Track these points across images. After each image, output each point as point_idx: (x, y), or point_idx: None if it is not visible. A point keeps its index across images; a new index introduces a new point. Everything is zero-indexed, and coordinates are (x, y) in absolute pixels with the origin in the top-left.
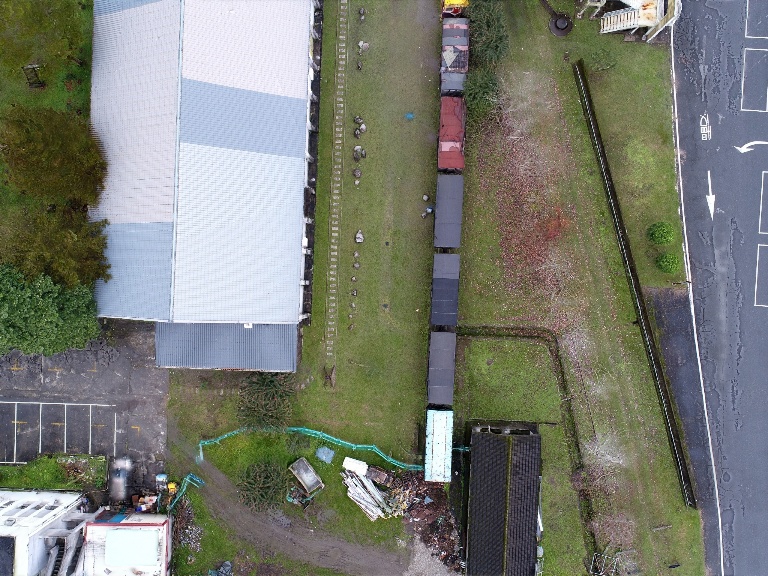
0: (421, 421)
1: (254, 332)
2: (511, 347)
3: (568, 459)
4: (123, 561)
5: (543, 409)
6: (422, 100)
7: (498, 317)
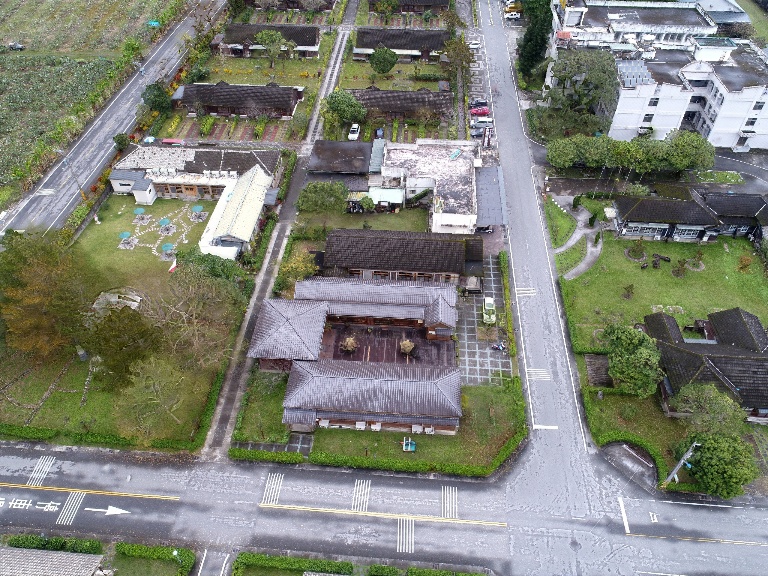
0: None
1: (732, 14)
2: None
3: None
4: None
5: None
6: (749, 3)
7: None
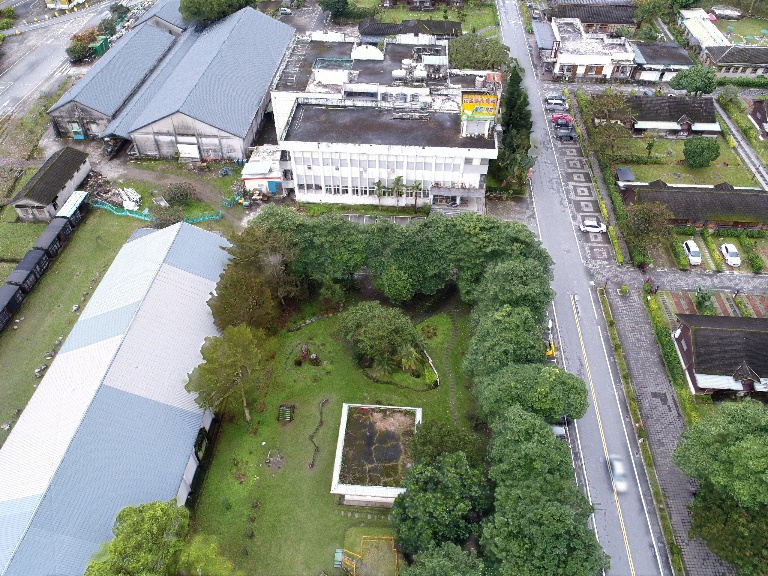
0: (84, 225)
1: None
2: (7, 254)
3: (7, 209)
4: (262, 164)
5: (6, 228)
6: None
7: (6, 267)
